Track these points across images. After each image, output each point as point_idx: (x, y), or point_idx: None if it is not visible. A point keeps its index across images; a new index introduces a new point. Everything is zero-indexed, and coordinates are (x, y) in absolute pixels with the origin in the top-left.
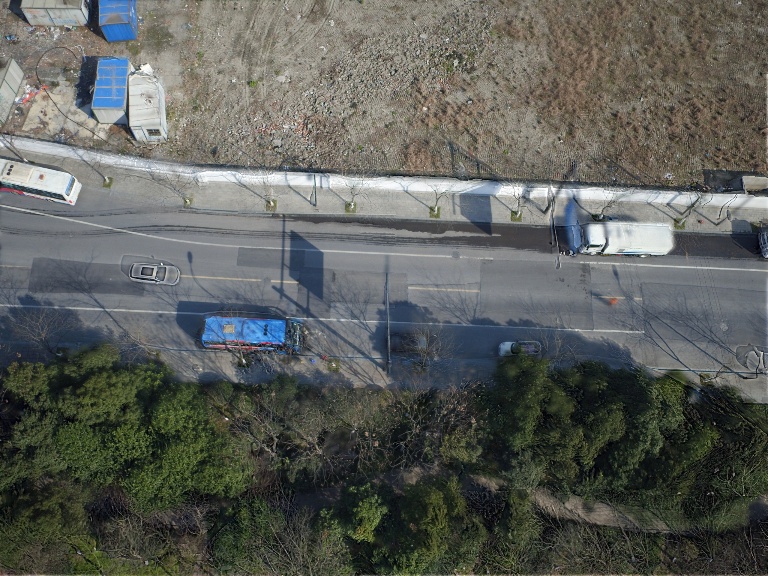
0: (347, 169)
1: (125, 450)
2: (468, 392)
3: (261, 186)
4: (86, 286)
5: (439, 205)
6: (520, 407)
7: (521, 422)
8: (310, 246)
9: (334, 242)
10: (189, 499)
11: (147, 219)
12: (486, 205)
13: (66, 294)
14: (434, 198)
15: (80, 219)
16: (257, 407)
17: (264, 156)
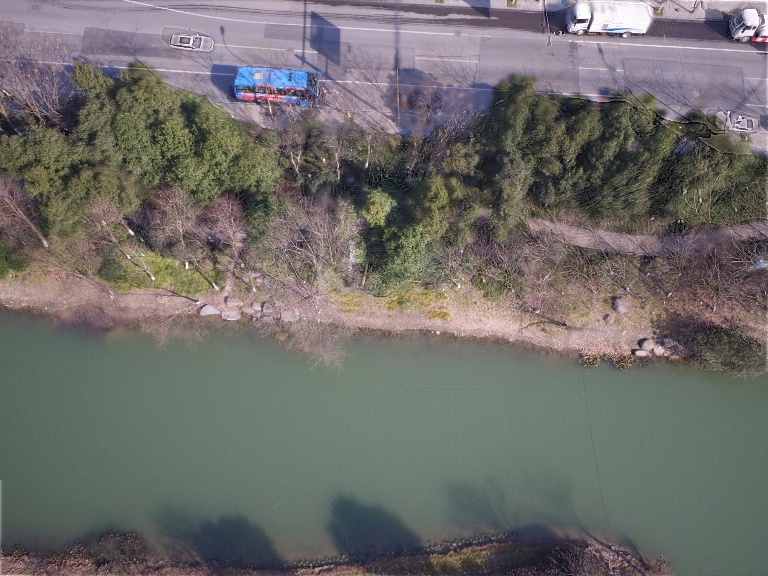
0: None
1: (172, 144)
2: (467, 112)
3: None
4: (131, 50)
5: None
6: (511, 109)
7: (512, 120)
8: (328, 24)
9: (350, 21)
10: (225, 202)
11: None
12: None
13: (114, 56)
14: None
15: None
16: (282, 142)
17: None
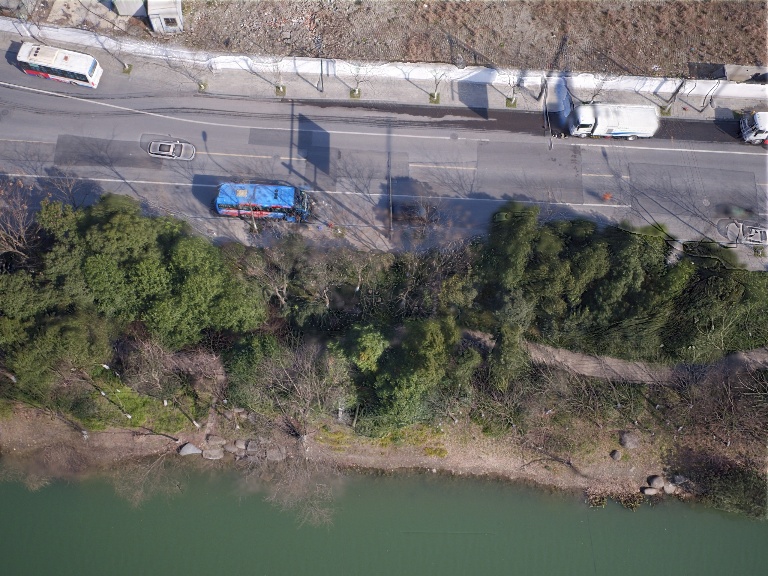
0: (352, 58)
1: (147, 284)
2: (464, 241)
3: (271, 73)
4: (108, 160)
5: (438, 91)
6: (512, 245)
7: (513, 258)
8: (317, 127)
9: (340, 124)
10: (205, 339)
11: (164, 102)
12: (483, 92)
13: (89, 167)
14: (434, 84)
15: (102, 101)
16: (268, 265)
17: (274, 46)
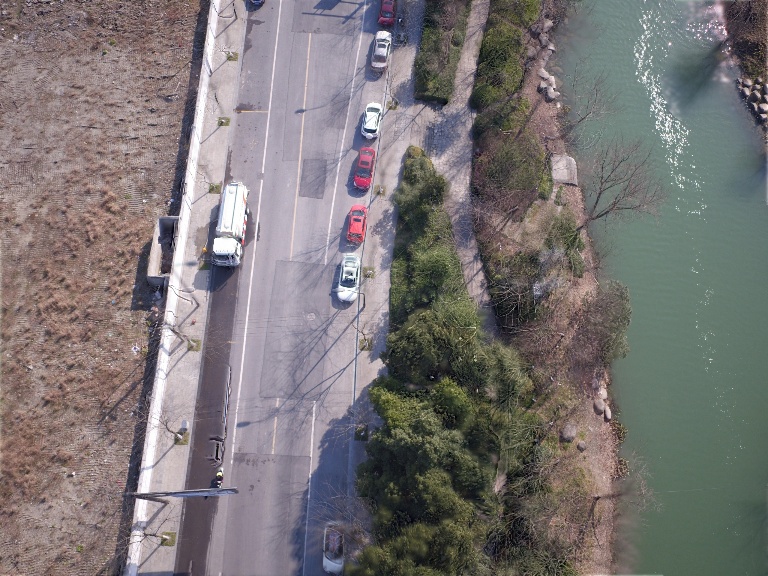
0: None
1: None
2: None
3: None
4: None
5: None
6: None
7: None
8: None
9: None
10: None
11: None
12: None
13: None
14: None
15: None
16: None
17: None
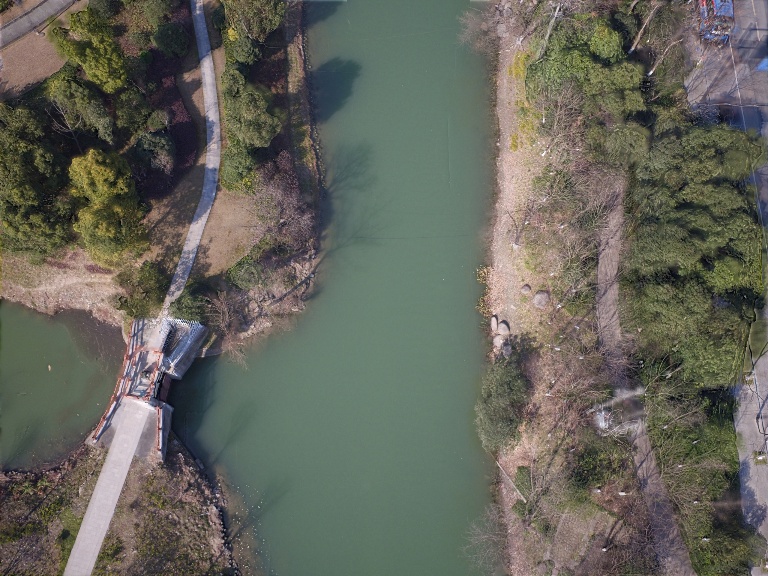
0: None
1: None
2: None
3: None
4: None
5: None
6: None
7: (716, 130)
8: None
9: None
10: None
11: None
12: None
13: None
14: None
15: None
16: (659, 5)
17: None
